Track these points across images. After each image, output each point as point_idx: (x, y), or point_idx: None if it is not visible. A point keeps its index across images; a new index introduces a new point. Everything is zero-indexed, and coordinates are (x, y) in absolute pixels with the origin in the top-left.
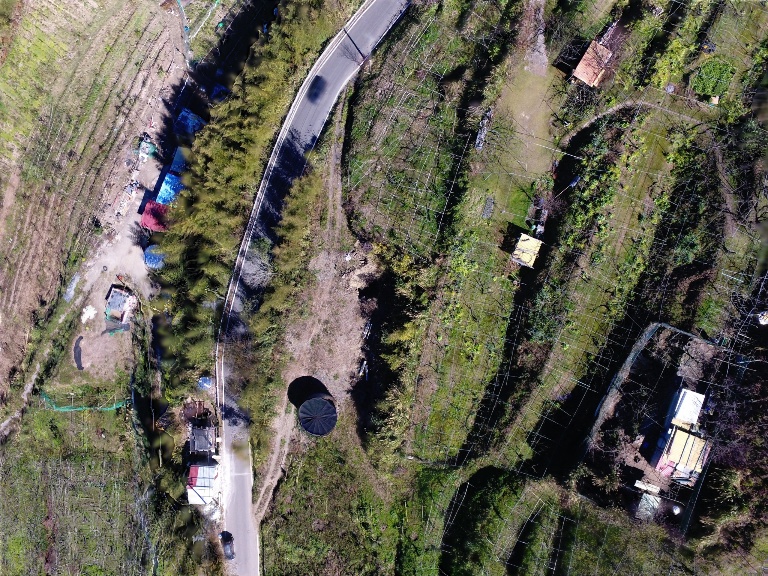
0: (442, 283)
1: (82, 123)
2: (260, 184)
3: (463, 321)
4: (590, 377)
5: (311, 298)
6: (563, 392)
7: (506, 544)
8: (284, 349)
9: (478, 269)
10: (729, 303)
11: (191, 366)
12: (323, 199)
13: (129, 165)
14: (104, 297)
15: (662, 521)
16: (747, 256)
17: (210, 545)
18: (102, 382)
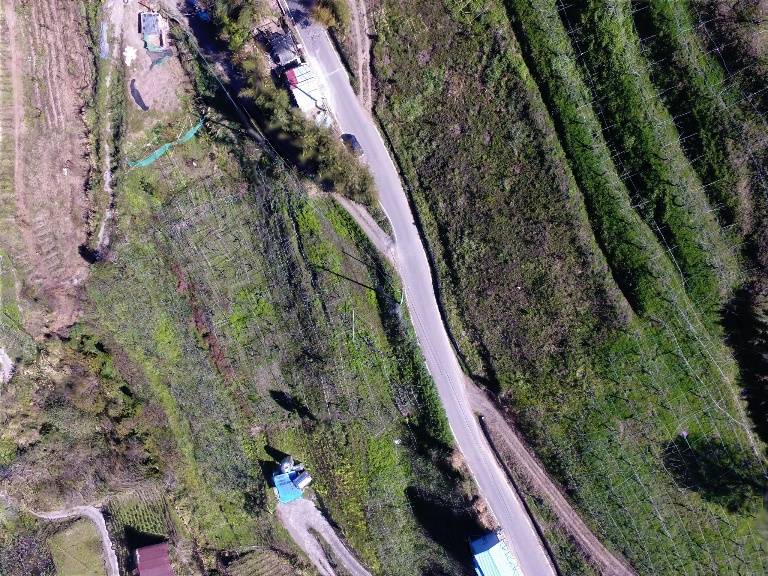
0: None
1: None
2: None
3: None
4: None
5: None
6: None
7: None
8: None
9: None
10: None
11: None
12: None
13: None
14: (137, 31)
15: None
16: None
17: (336, 156)
18: (171, 115)
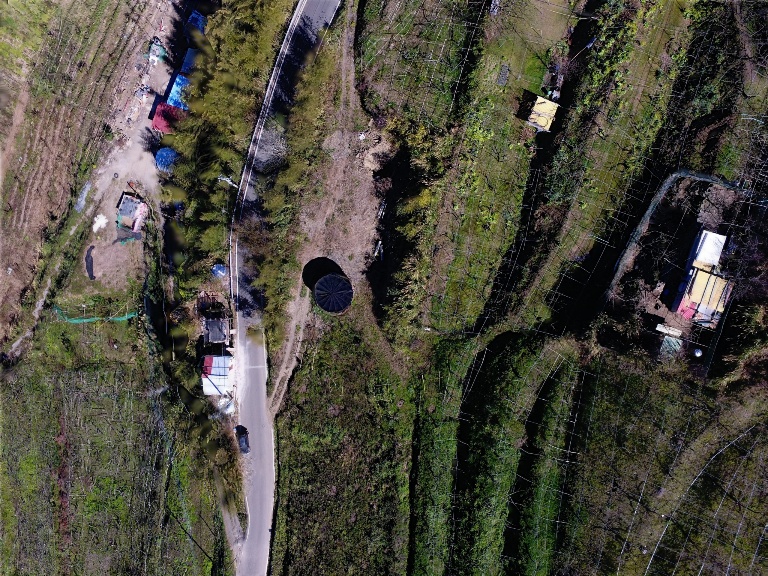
0: (458, 152)
1: (91, 33)
2: (272, 71)
3: (479, 190)
4: (609, 233)
5: (325, 177)
6: (581, 253)
7: (526, 401)
8: (299, 229)
9: (494, 137)
10: (750, 144)
11: (205, 255)
12: (336, 80)
13: (139, 70)
14: (115, 205)
15: (684, 363)
16: (767, 100)
17: (225, 440)
18: (114, 292)
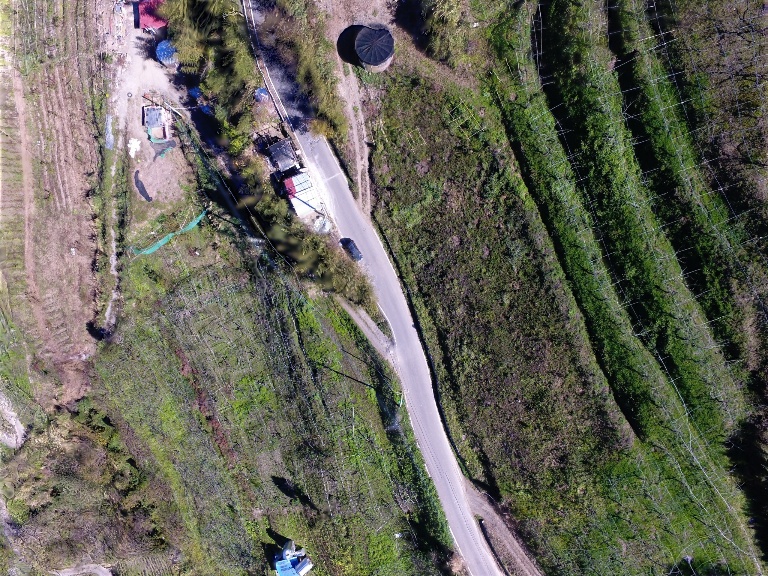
0: None
1: None
2: None
3: None
4: None
5: None
6: None
7: (599, 17)
8: (316, 10)
9: None
10: None
11: (242, 91)
12: None
13: None
14: (140, 124)
15: None
16: None
17: (335, 259)
18: (174, 205)
